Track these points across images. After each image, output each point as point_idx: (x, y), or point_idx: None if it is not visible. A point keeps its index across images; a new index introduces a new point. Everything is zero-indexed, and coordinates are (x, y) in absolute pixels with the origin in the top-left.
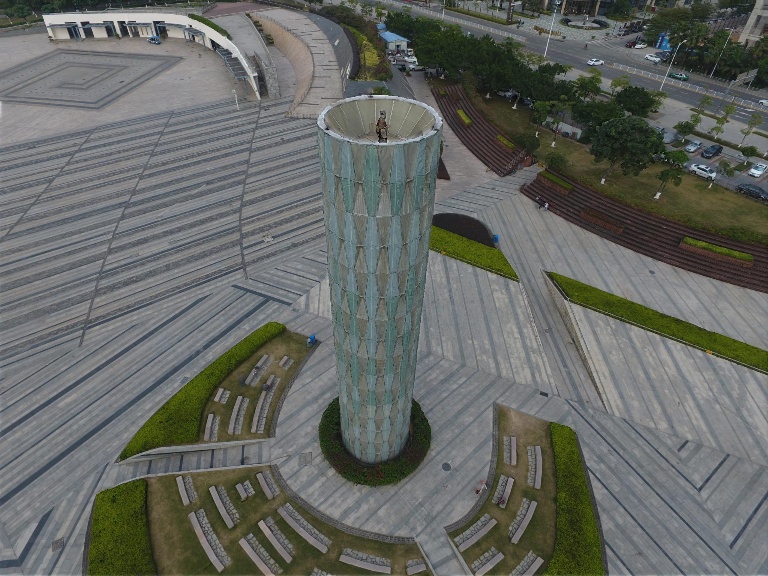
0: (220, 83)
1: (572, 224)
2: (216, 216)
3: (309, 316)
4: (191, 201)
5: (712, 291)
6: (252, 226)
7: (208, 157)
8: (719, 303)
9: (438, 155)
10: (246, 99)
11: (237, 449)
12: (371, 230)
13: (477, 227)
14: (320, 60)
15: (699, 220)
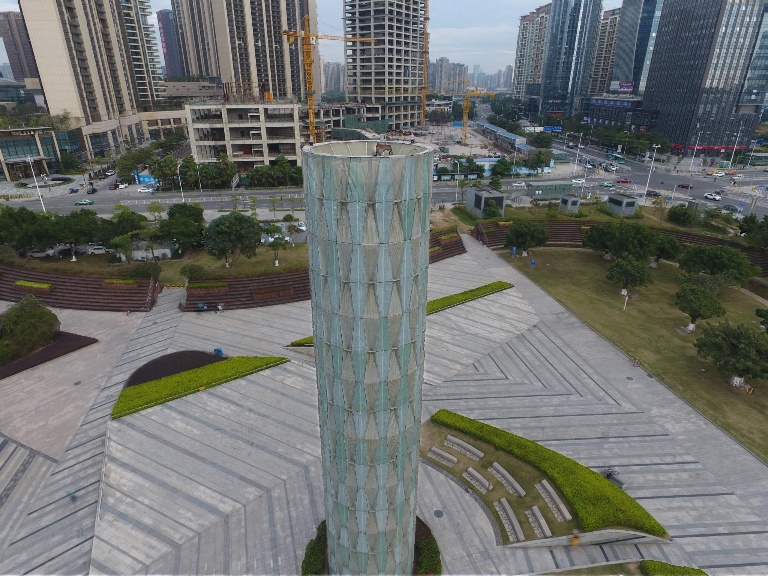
0: None
1: (254, 308)
2: None
3: None
4: None
5: None
6: None
7: None
8: None
9: None
10: None
11: None
12: None
13: (191, 355)
14: None
15: None
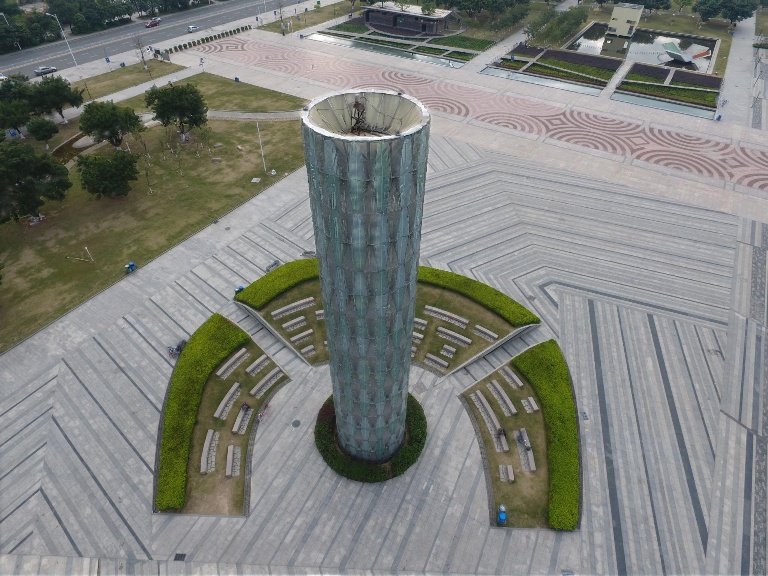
0: None
1: None
2: None
3: (540, 569)
4: None
5: None
6: None
7: None
8: None
9: None
10: None
11: (479, 377)
12: None
13: None
14: None
15: None
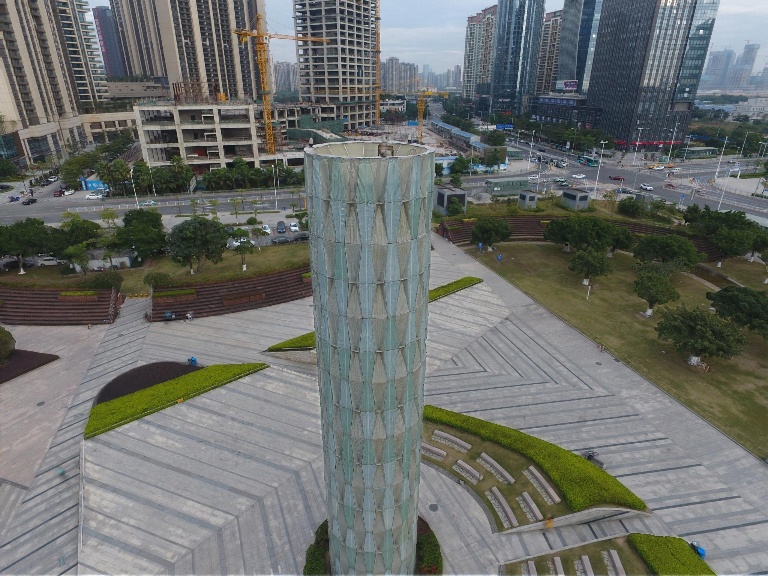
0: None
1: (225, 315)
2: None
3: None
4: None
5: None
6: None
7: None
8: None
9: None
10: None
11: None
12: None
13: (163, 367)
14: None
15: (297, 261)
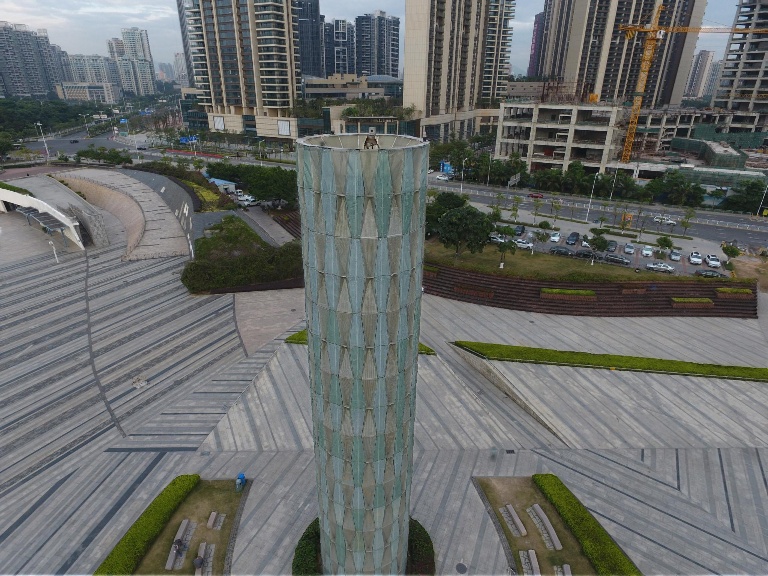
0: (25, 241)
1: (450, 300)
2: (58, 376)
3: (226, 455)
4: (15, 367)
5: (581, 325)
6: (114, 375)
7: (28, 315)
8: (591, 332)
9: None
10: (66, 251)
11: None
12: (380, 256)
13: None
14: (148, 206)
15: (545, 273)
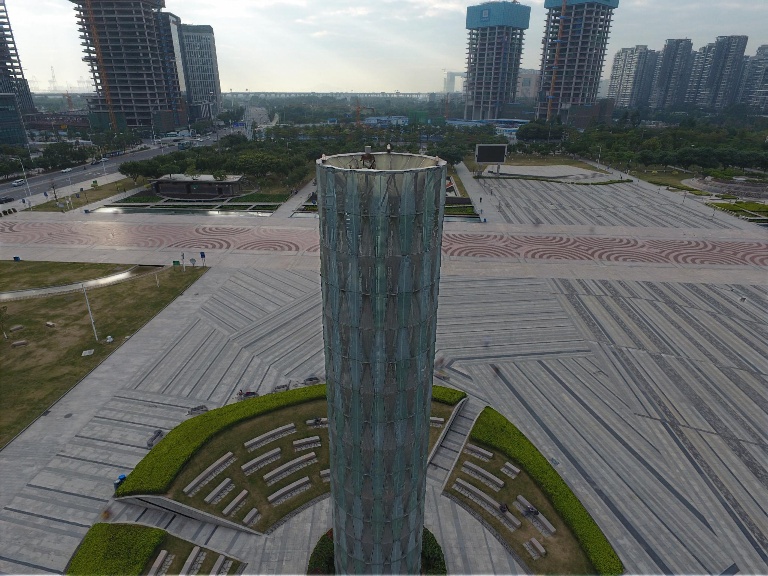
0: None
1: None
2: None
3: None
4: None
5: None
6: None
7: None
8: None
9: (326, 201)
10: None
11: (449, 466)
12: None
13: None
14: None
15: None
